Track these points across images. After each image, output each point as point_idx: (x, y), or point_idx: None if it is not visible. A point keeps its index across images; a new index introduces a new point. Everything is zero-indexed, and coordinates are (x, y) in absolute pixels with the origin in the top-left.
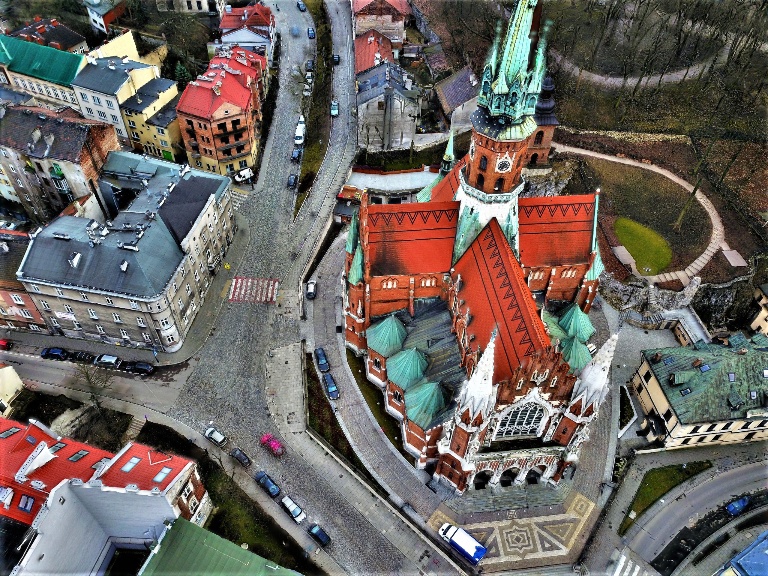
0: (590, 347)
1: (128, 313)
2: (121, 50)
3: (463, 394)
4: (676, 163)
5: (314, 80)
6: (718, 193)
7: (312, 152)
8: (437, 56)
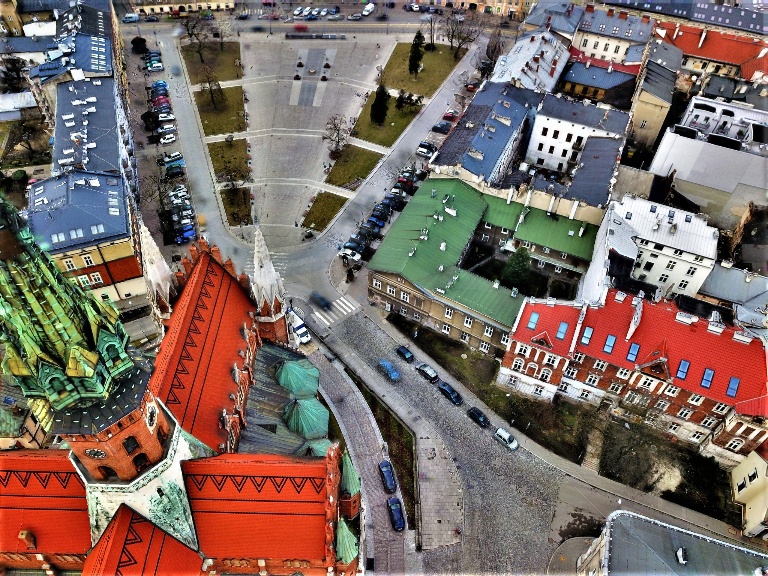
0: None
1: None
2: None
3: None
4: None
5: None
6: None
7: None
8: None
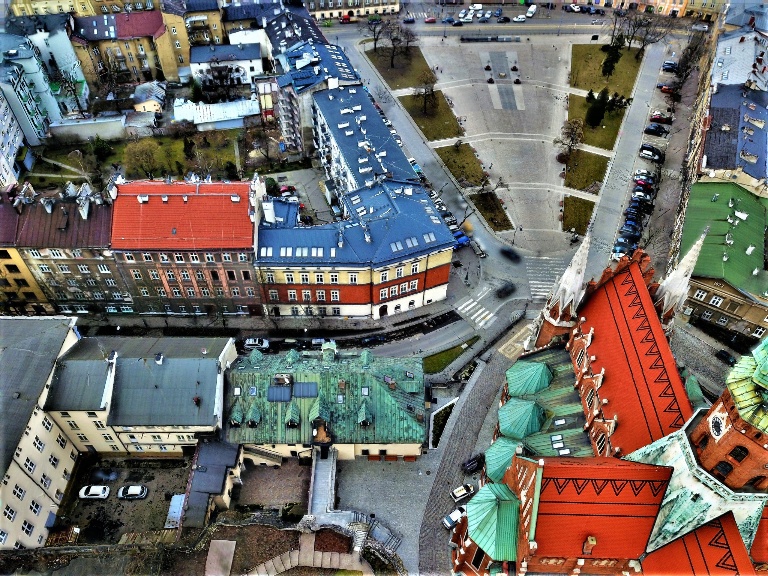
0: (462, 490)
1: None
2: None
3: None
4: None
5: None
6: None
7: None
8: None
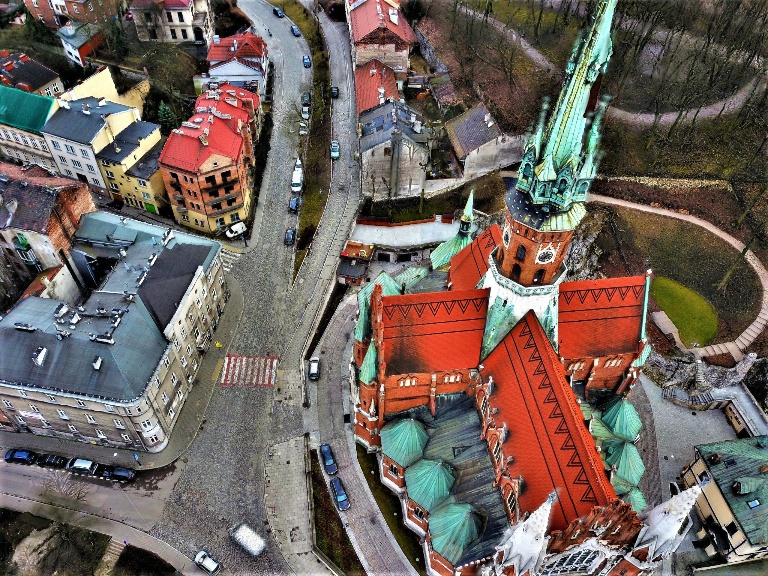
0: None
1: (103, 415)
2: (97, 89)
3: (507, 548)
4: (717, 213)
5: (311, 115)
6: (766, 248)
7: (311, 201)
8: (445, 88)
